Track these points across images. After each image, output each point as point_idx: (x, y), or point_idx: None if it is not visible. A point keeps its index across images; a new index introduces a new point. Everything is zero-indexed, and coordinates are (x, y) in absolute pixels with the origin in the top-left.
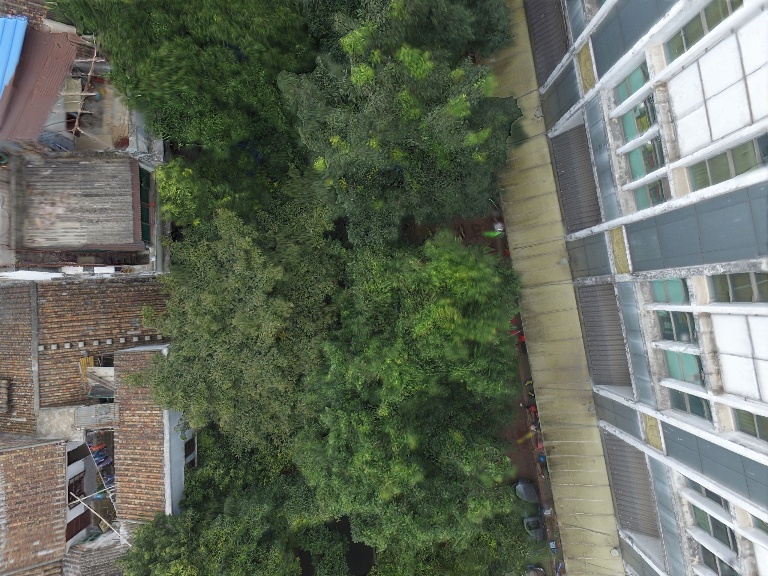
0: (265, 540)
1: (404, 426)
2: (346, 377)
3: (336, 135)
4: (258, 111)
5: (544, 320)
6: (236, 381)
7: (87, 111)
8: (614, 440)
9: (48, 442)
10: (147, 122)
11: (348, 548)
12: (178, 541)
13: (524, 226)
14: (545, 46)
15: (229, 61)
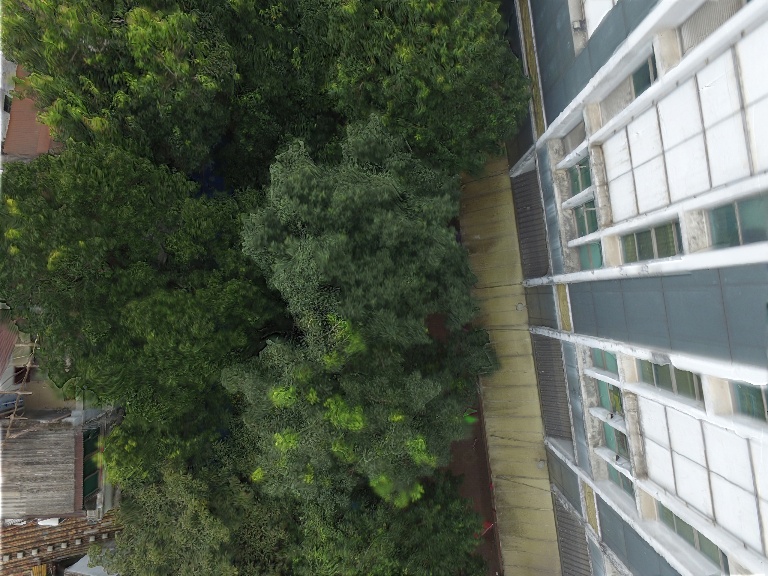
0: None
1: None
2: None
3: (282, 427)
4: None
5: (519, 514)
6: None
7: (20, 418)
8: None
9: None
10: None
11: None
12: None
13: (503, 414)
14: (530, 239)
15: (171, 358)
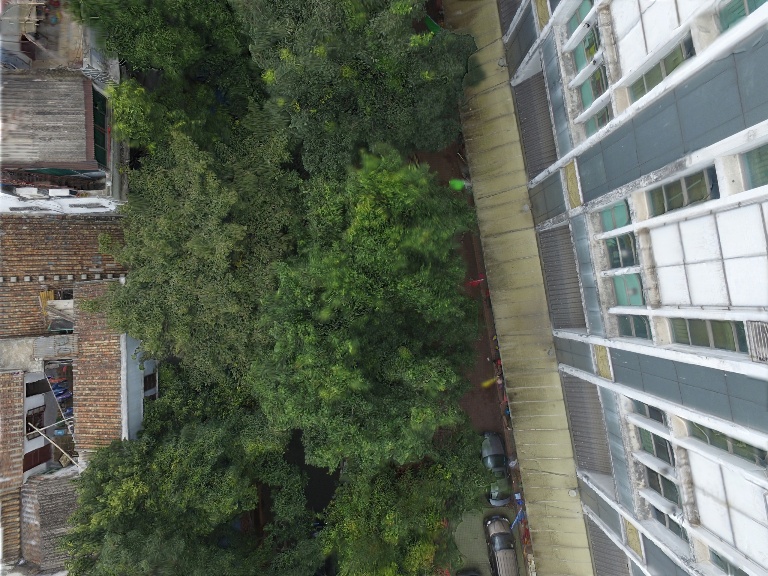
0: (221, 466)
1: (350, 337)
2: (295, 293)
3: (286, 53)
4: (212, 34)
5: (507, 268)
6: (193, 309)
7: None
8: (572, 382)
9: (5, 371)
10: (103, 46)
11: (307, 483)
12: (131, 462)
13: (488, 176)
14: None
15: None
